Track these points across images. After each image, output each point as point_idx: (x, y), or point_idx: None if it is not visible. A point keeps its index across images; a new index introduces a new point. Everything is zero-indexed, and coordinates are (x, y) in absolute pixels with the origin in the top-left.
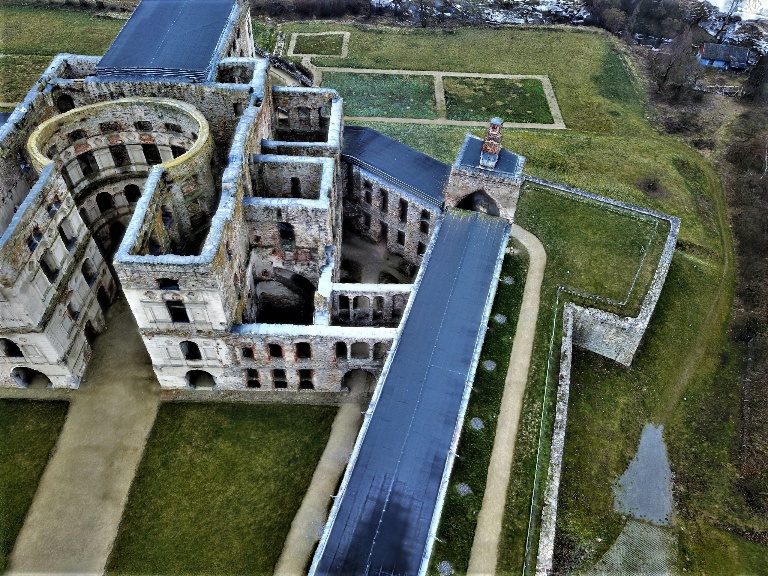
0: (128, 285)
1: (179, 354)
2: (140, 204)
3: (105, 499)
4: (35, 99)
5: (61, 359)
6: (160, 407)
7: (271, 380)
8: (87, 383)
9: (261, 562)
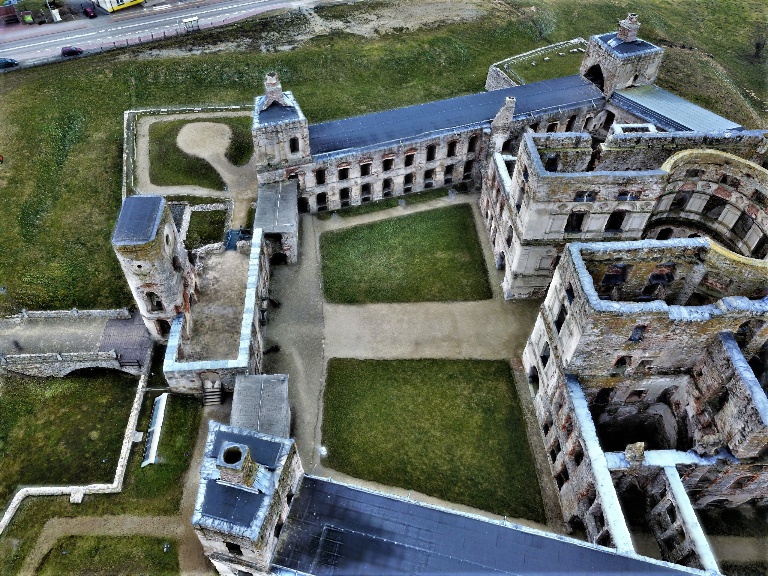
0: (560, 267)
1: (541, 348)
2: (647, 241)
3: (416, 345)
4: (750, 136)
5: (516, 273)
6: (503, 361)
7: (552, 443)
8: (512, 304)
9: (376, 469)
